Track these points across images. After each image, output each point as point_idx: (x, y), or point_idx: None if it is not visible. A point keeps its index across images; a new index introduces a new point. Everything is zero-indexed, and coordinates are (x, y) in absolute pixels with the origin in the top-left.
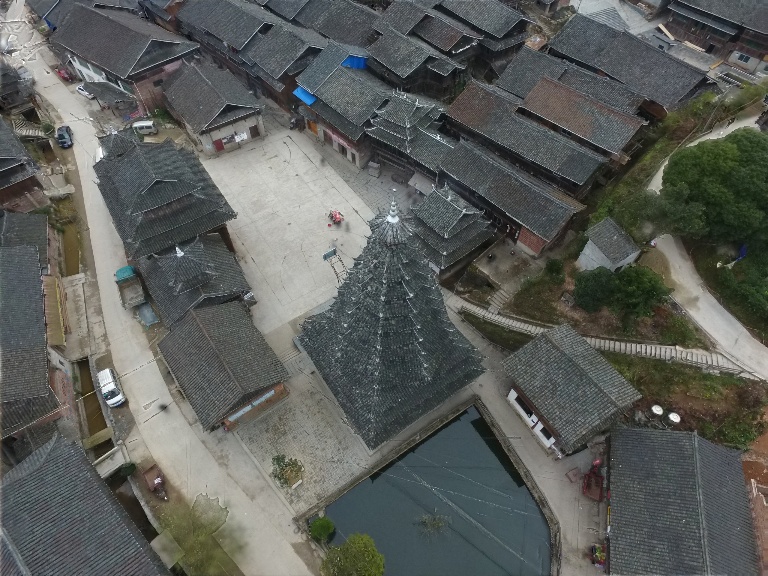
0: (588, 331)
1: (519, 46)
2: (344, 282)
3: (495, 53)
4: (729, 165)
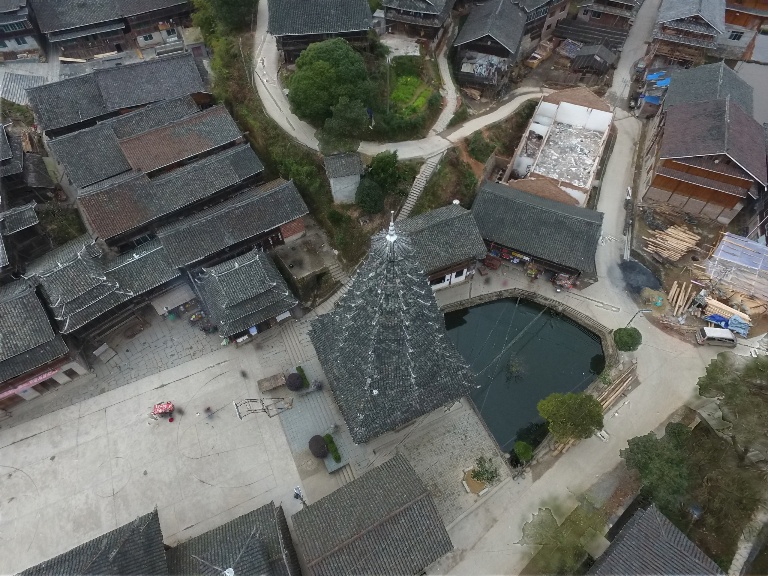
0: (389, 221)
1: None
2: (373, 338)
3: (18, 174)
4: (333, 72)
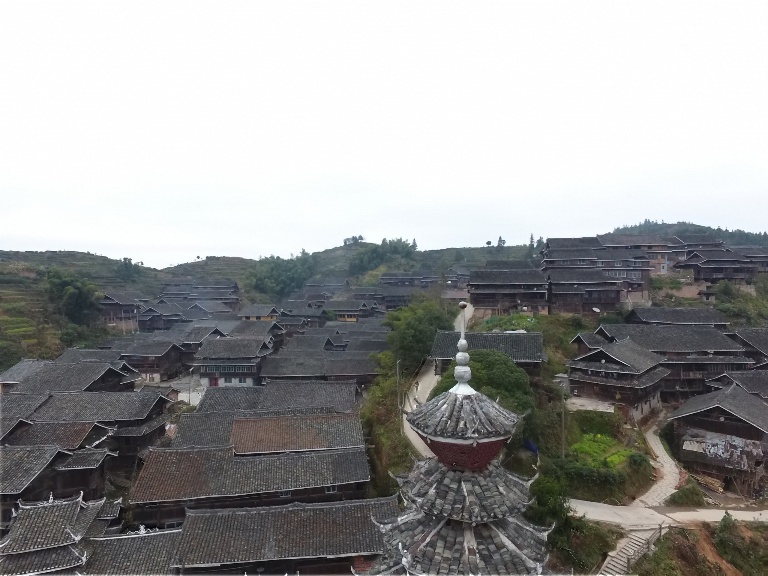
0: None
1: (160, 430)
2: None
3: (138, 441)
4: (483, 373)
